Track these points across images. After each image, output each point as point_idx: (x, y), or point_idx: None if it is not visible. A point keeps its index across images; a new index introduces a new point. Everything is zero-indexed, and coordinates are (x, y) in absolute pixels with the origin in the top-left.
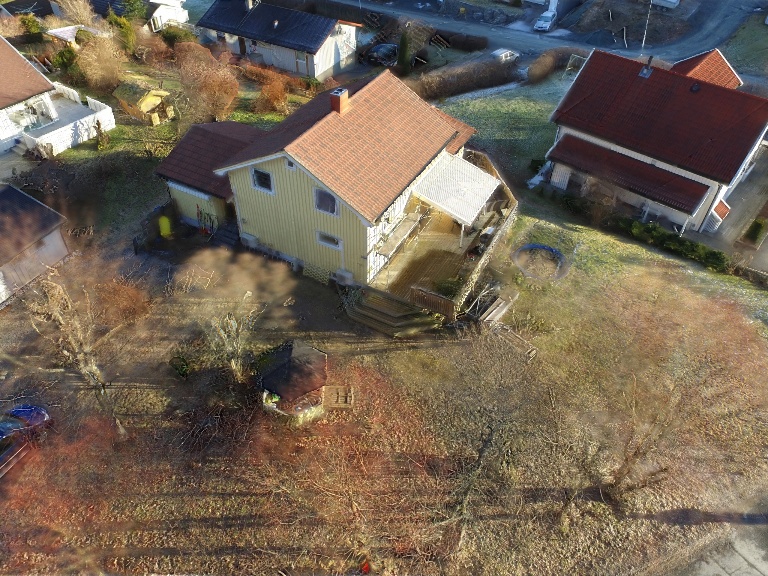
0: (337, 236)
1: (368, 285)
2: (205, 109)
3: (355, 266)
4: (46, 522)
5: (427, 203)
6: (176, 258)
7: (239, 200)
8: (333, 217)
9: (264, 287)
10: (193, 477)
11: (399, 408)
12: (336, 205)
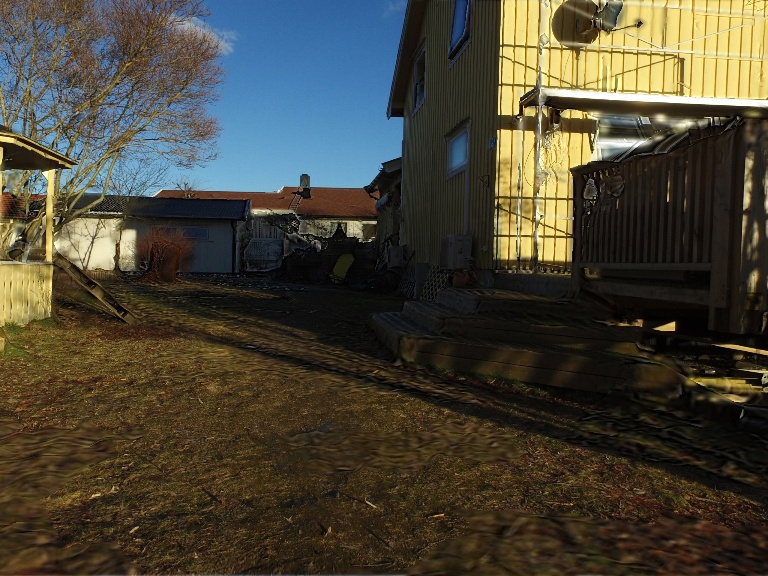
0: (465, 116)
1: (496, 269)
2: None
3: (480, 202)
4: None
5: None
6: (301, 281)
7: (404, 169)
8: (465, 55)
9: (329, 298)
10: None
11: None
12: (469, 2)
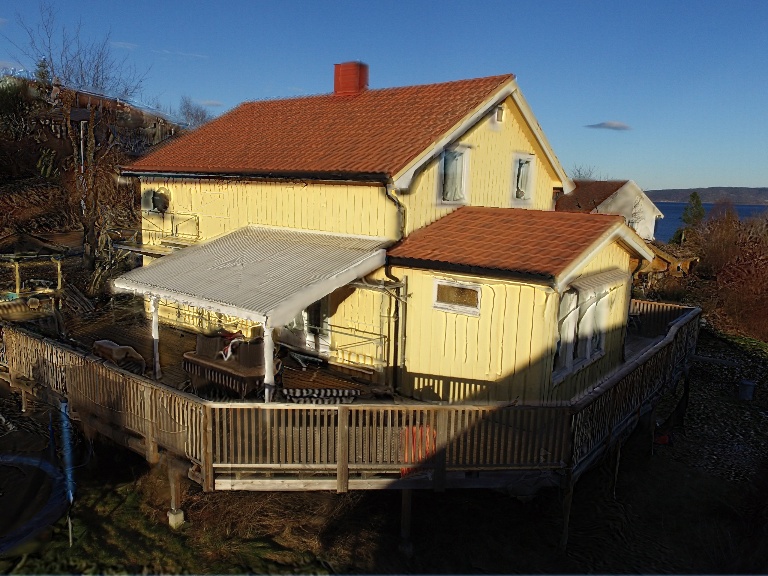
0: None
1: (146, 316)
2: (670, 282)
3: None
4: (48, 261)
5: None
6: None
7: None
8: None
9: None
10: (6, 278)
11: None
12: None
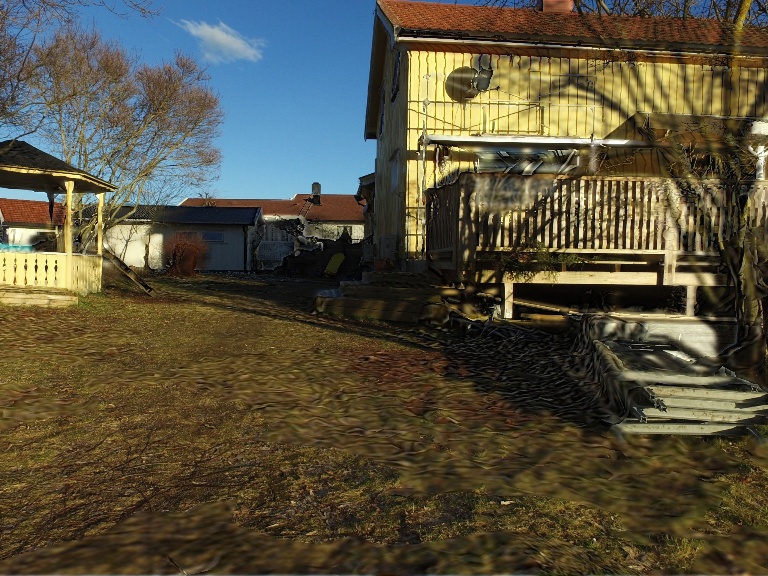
0: None
1: (407, 258)
2: None
3: None
4: None
5: (660, 129)
6: (297, 275)
7: None
8: None
9: None
10: None
11: (4, 325)
12: (399, 63)
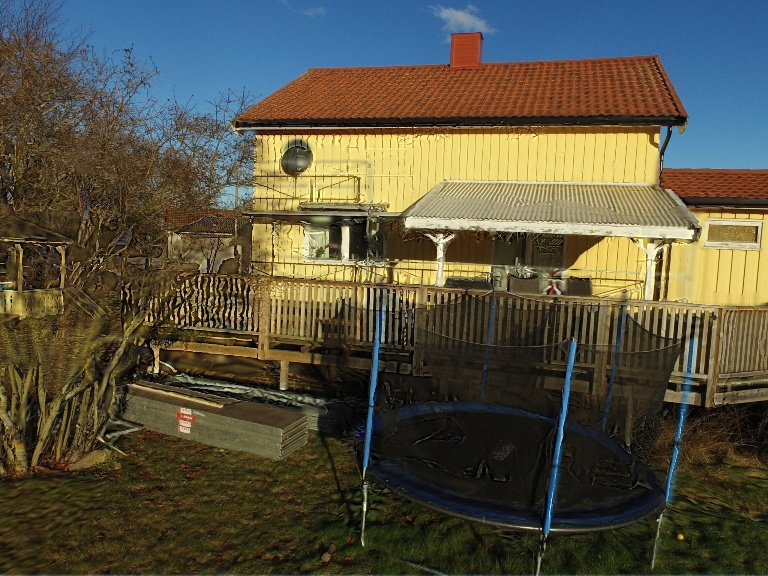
0: None
1: None
2: None
3: None
4: None
5: None
6: None
7: None
8: None
9: None
10: None
11: None
12: None
